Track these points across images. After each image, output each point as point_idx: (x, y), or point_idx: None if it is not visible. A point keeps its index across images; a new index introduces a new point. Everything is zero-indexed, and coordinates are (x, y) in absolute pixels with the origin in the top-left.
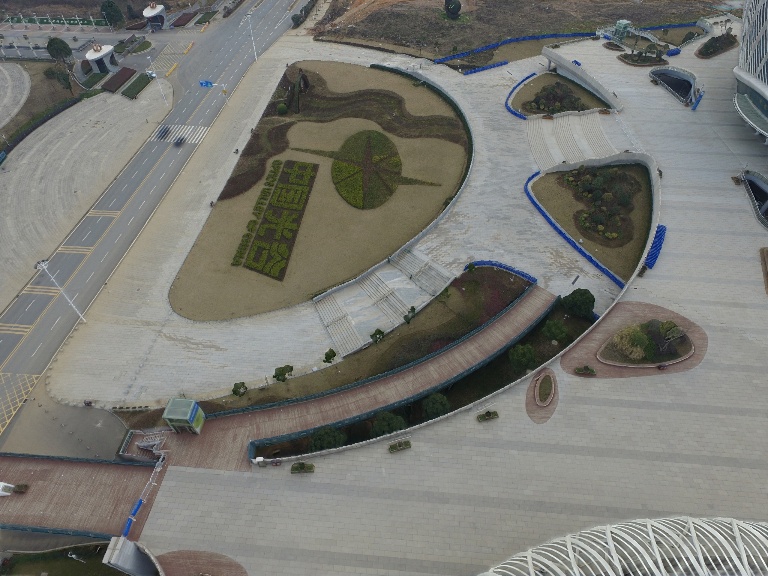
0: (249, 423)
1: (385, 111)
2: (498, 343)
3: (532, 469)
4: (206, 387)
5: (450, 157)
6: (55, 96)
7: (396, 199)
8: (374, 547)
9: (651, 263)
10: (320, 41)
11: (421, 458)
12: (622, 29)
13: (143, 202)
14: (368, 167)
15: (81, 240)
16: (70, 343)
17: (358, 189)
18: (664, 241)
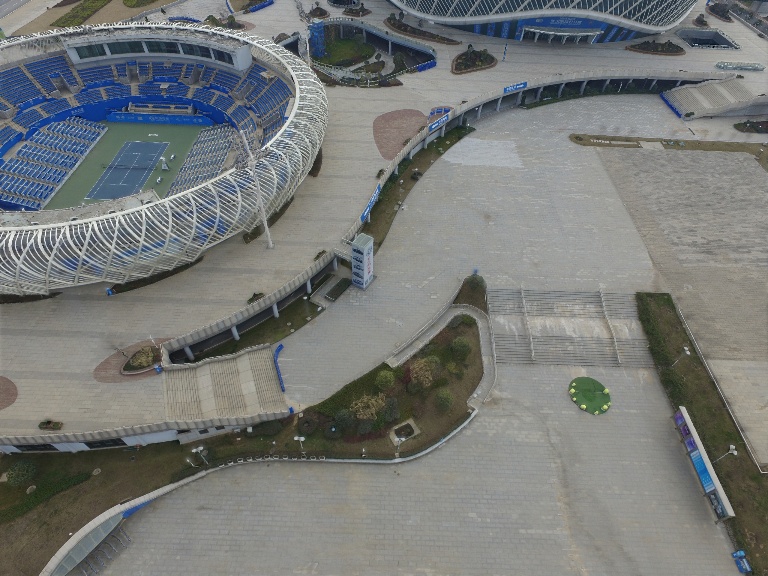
0: None
1: None
2: None
3: None
4: None
5: None
6: None
7: (154, 4)
8: None
9: (251, 9)
10: None
11: None
12: None
13: (7, 8)
14: None
15: None
16: None
17: (134, 0)
18: (270, 6)
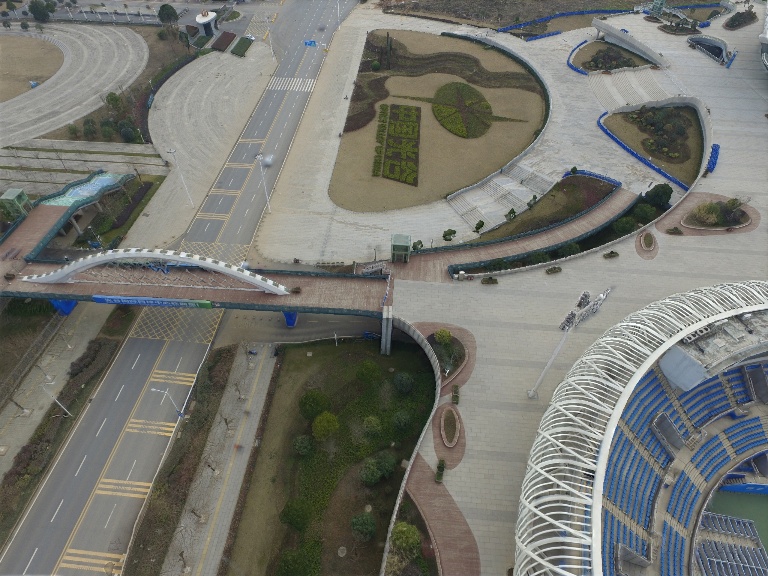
0: (441, 258)
1: (465, 68)
2: (602, 220)
3: (649, 284)
4: (381, 252)
5: (530, 102)
6: (174, 53)
7: (493, 131)
8: (552, 321)
9: (712, 168)
10: (390, 14)
11: (570, 277)
12: (659, 5)
13: (281, 133)
14: (463, 109)
15: (241, 159)
16: (264, 225)
17: (460, 124)
18: (718, 155)
